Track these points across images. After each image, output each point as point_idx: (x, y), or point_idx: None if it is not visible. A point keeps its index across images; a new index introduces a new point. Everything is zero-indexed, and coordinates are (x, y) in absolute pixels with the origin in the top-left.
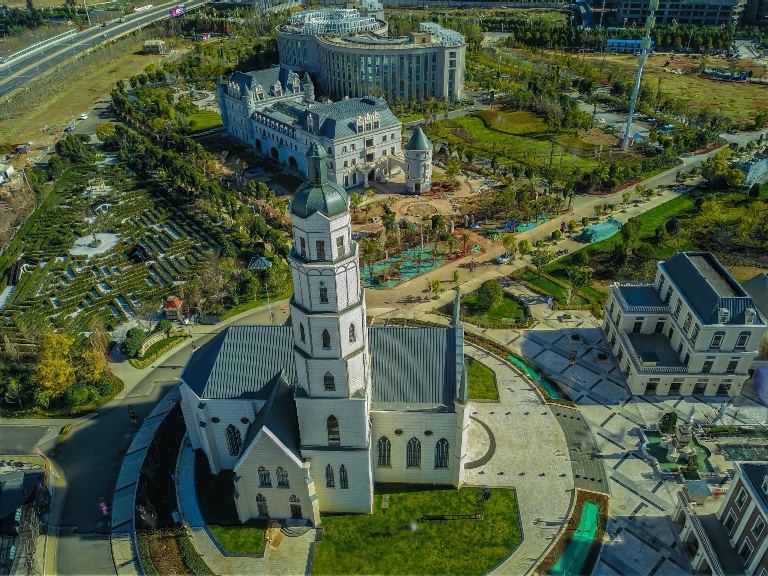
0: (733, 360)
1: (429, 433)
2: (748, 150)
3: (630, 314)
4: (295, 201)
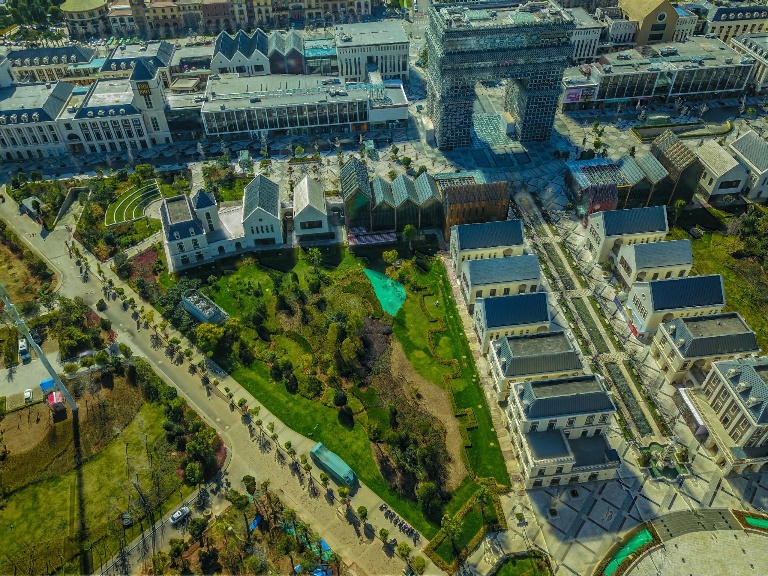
0: None
1: None
2: (121, 296)
3: (574, 458)
4: None
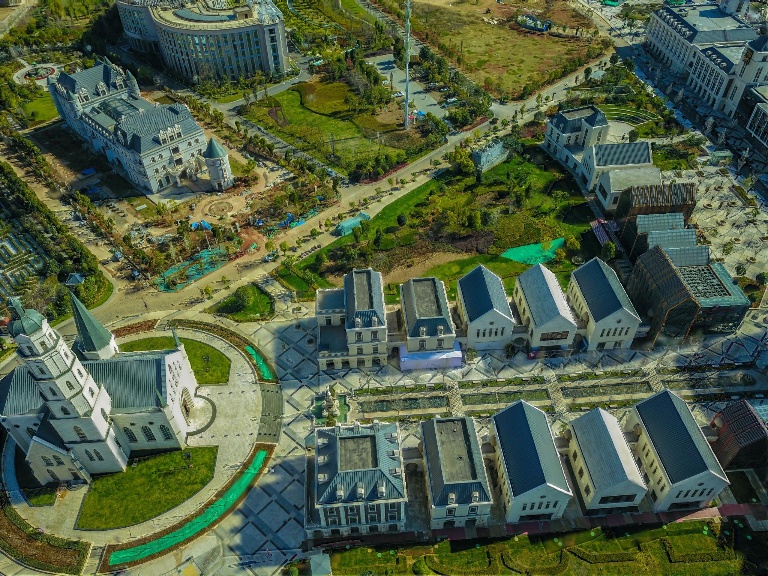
0: (374, 346)
1: (152, 423)
2: None
3: (319, 315)
4: (8, 327)
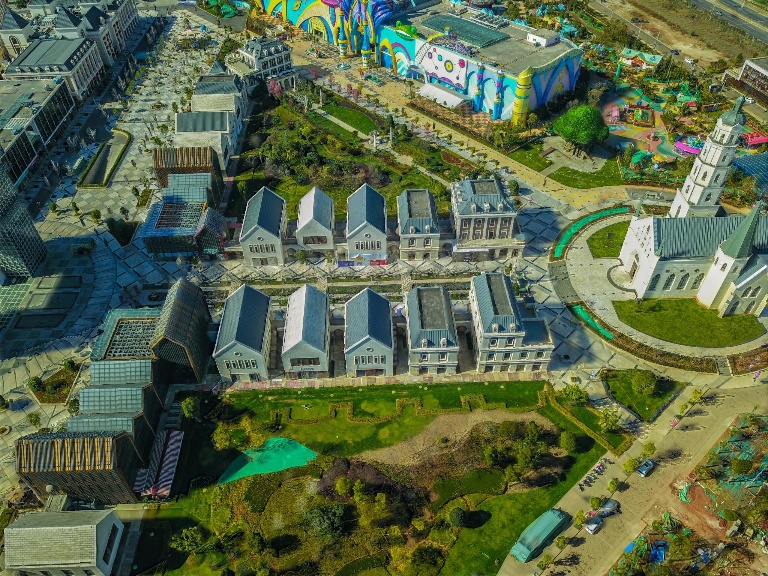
0: None
1: None
2: None
3: None
4: None
